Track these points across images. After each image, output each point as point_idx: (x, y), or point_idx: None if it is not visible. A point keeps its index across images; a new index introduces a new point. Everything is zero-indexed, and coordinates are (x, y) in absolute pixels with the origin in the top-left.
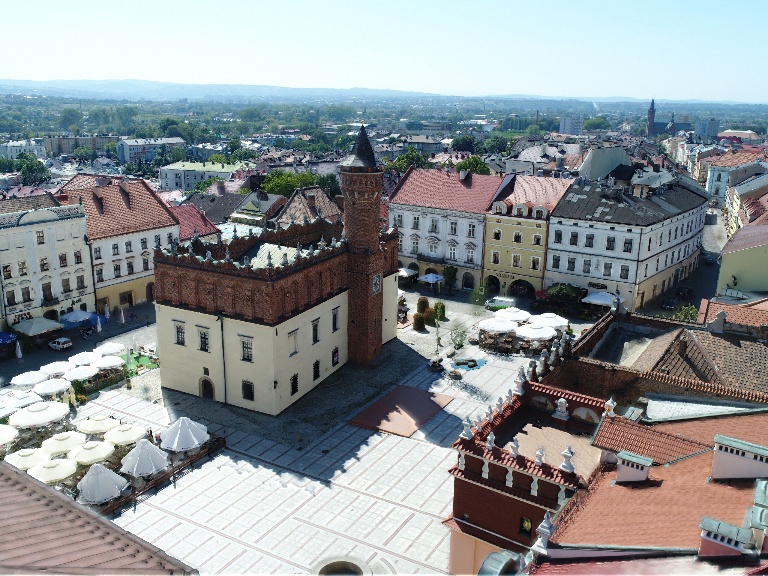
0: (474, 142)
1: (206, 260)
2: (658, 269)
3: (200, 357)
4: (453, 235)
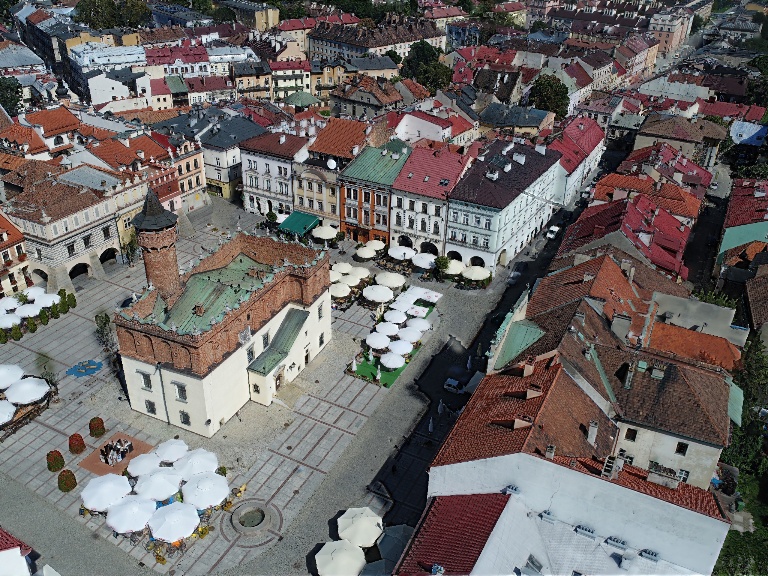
0: None
1: None
2: None
3: None
4: None
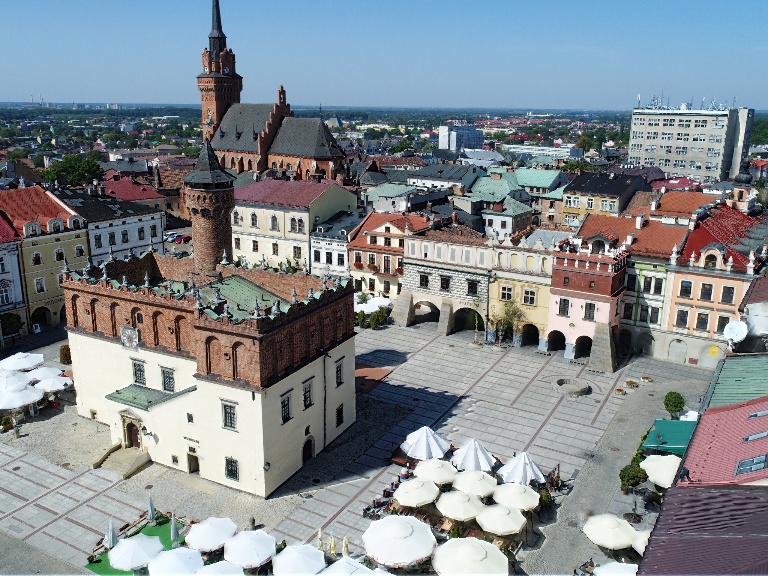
0: None
1: None
2: None
3: None
4: None
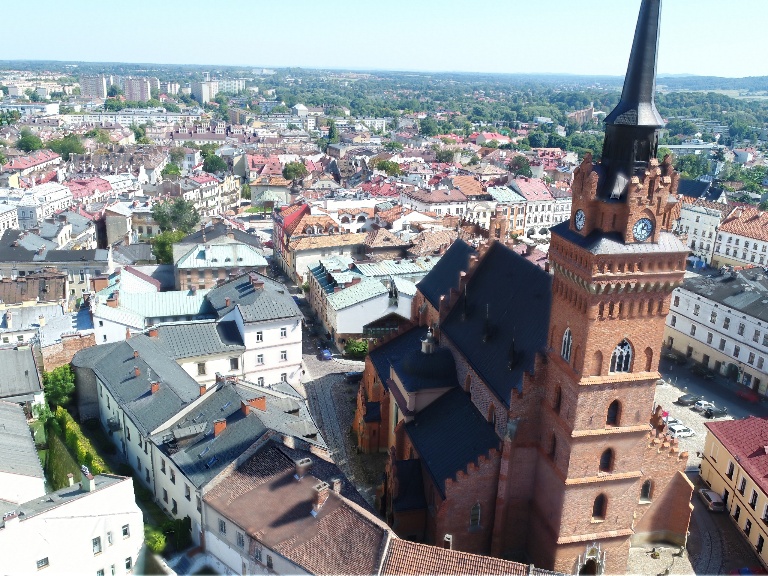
0: None
1: None
2: None
3: None
4: None
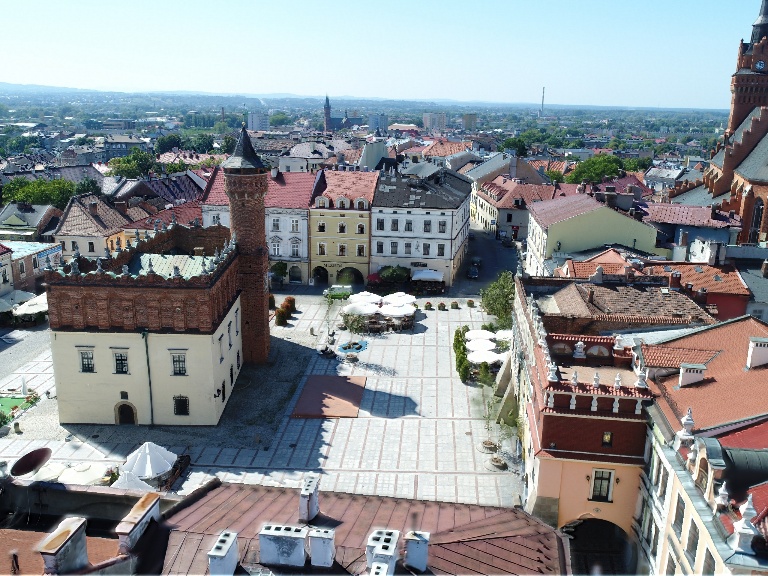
0: (181, 141)
1: (123, 275)
2: (459, 245)
3: (116, 381)
4: (276, 232)
